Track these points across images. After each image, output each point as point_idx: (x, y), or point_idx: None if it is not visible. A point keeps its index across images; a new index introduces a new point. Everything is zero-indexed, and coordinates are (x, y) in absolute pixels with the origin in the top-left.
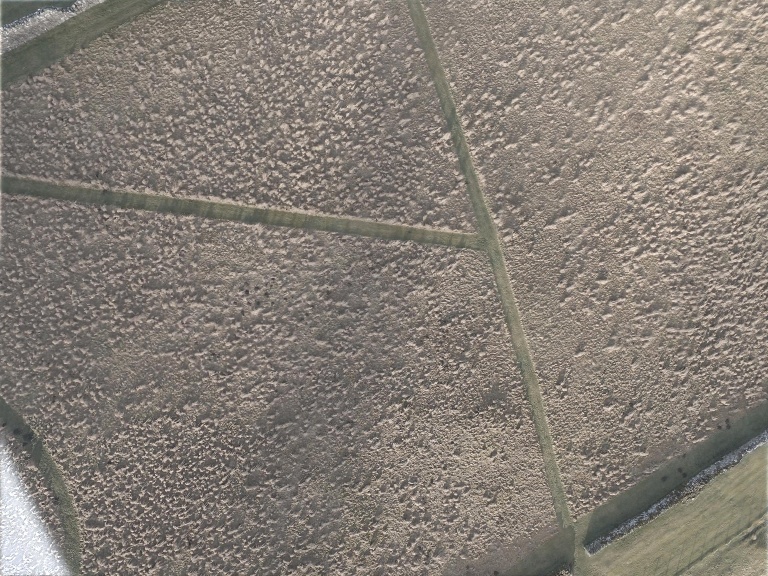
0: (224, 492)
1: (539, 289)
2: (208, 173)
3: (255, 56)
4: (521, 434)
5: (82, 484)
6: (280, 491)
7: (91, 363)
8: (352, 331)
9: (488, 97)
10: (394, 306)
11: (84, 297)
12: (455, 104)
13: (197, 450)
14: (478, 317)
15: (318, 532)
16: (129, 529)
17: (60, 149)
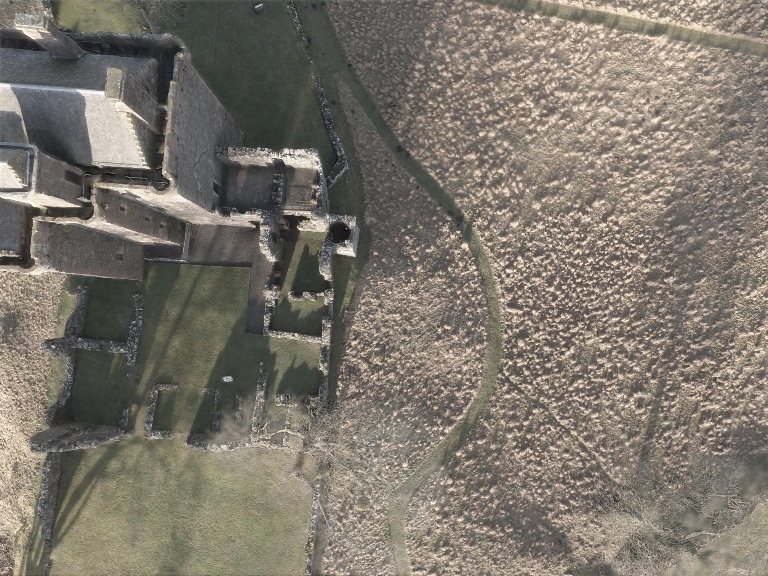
0: (628, 286)
1: None
2: None
3: None
4: None
5: (506, 267)
6: (677, 289)
7: (512, 156)
8: (742, 144)
9: None
10: None
11: (505, 94)
12: None
13: (602, 246)
14: None
15: (711, 330)
16: (545, 314)
17: None
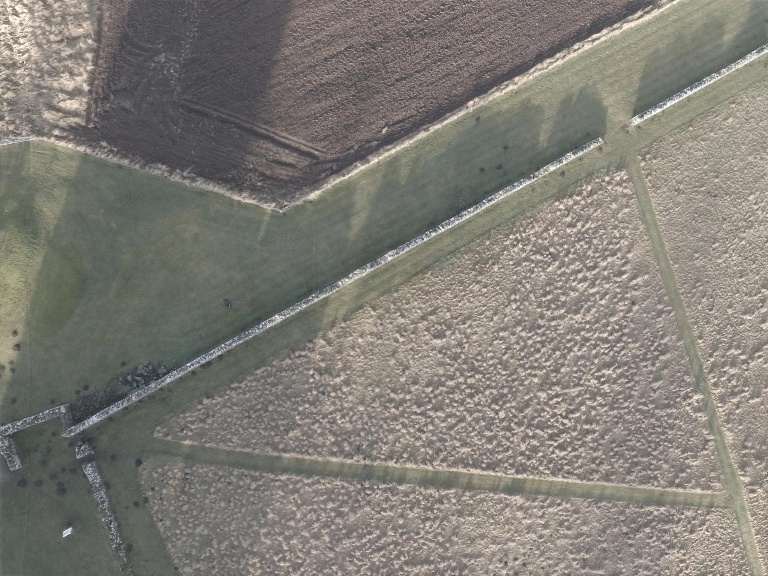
0: None
1: None
2: (468, 444)
3: (511, 321)
4: None
5: None
6: None
7: None
8: None
9: (734, 352)
10: (648, 572)
11: None
12: (703, 361)
13: None
14: (726, 575)
15: None
16: None
17: (322, 424)
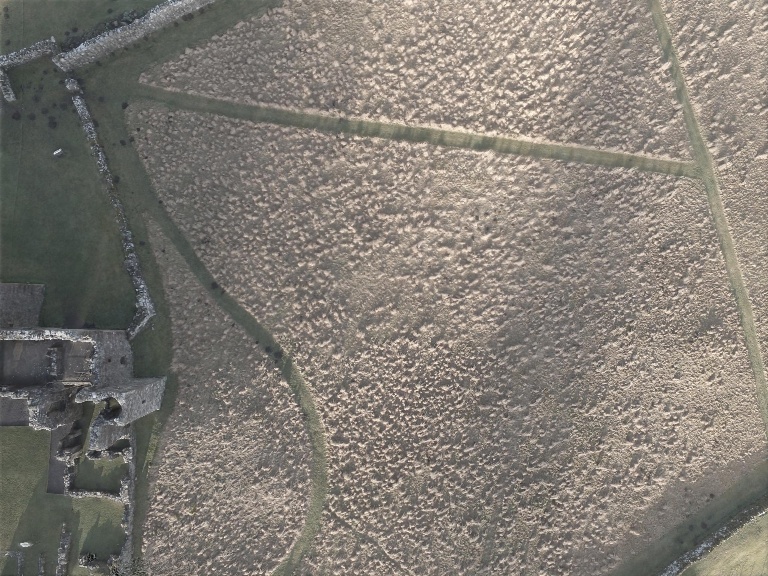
0: (459, 411)
1: (751, 218)
2: (439, 102)
3: None
4: (736, 360)
5: (329, 401)
6: (512, 411)
7: (334, 285)
8: (577, 256)
9: (702, 28)
10: (617, 232)
11: (325, 221)
12: (671, 35)
13: (432, 371)
14: (695, 244)
15: (548, 451)
16: (372, 445)
17: (299, 79)
